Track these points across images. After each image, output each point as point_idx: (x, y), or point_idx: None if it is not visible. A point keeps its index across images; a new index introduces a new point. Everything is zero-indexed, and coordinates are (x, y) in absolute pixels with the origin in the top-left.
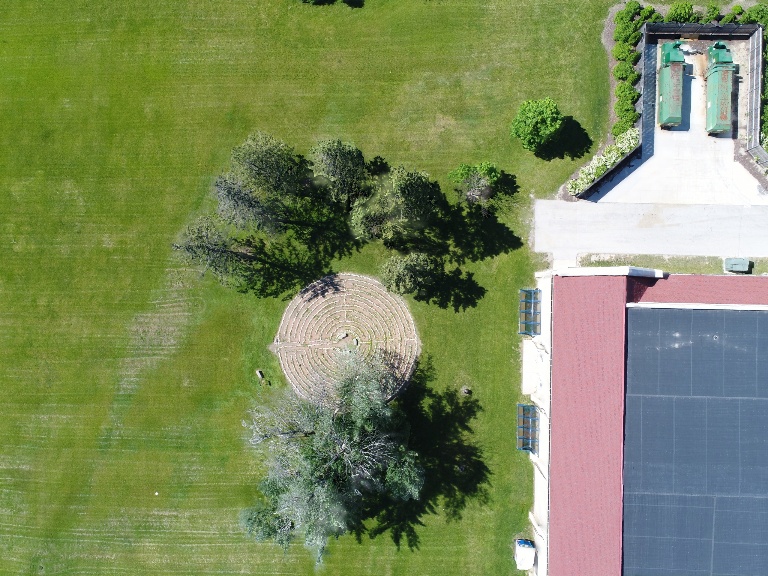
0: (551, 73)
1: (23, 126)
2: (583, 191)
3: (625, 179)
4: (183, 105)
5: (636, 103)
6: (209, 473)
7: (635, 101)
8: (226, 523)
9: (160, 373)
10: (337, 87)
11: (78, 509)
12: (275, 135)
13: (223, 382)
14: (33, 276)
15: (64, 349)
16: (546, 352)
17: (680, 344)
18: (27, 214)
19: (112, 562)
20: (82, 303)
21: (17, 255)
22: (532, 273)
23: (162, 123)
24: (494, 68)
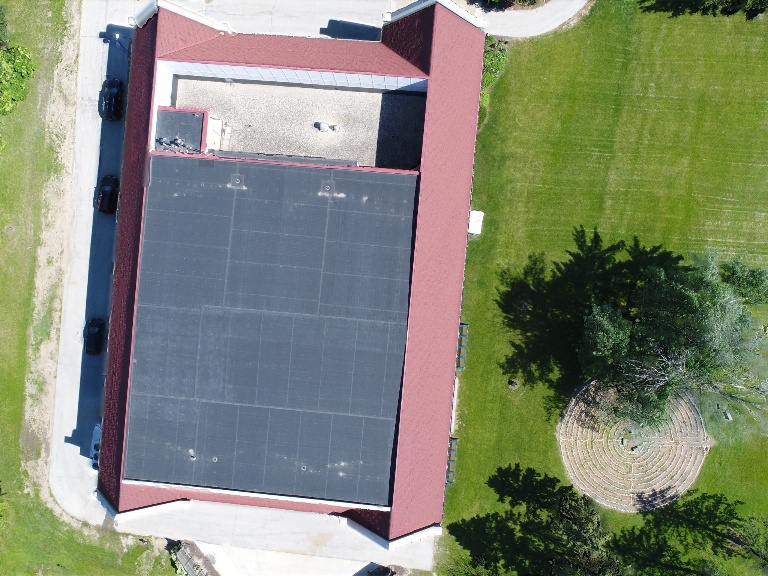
0: None
1: None
2: None
3: None
4: None
5: None
6: None
7: None
8: None
9: None
10: None
11: None
12: None
13: None
14: None
15: None
16: None
17: (339, 465)
18: None
19: None
20: None
21: None
22: None
23: None
24: None
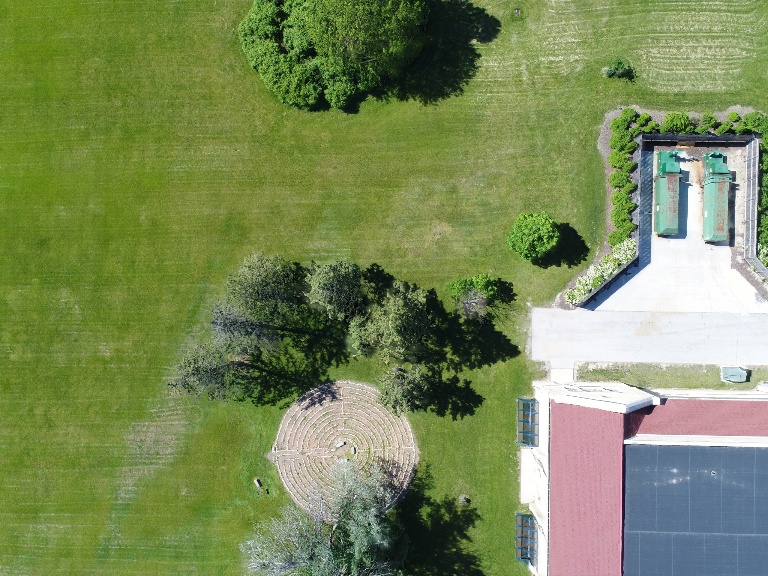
0: (547, 179)
1: (18, 234)
2: (580, 302)
3: (622, 287)
4: (179, 212)
5: (633, 212)
6: None
7: (632, 211)
8: None
9: (158, 482)
10: (333, 194)
11: None
12: (271, 242)
13: (221, 491)
14: (30, 385)
15: (61, 458)
16: (544, 472)
17: (678, 480)
18: (23, 323)
19: None
20: (79, 412)
21: (13, 364)
22: (530, 382)
23: (158, 231)
24: (490, 174)
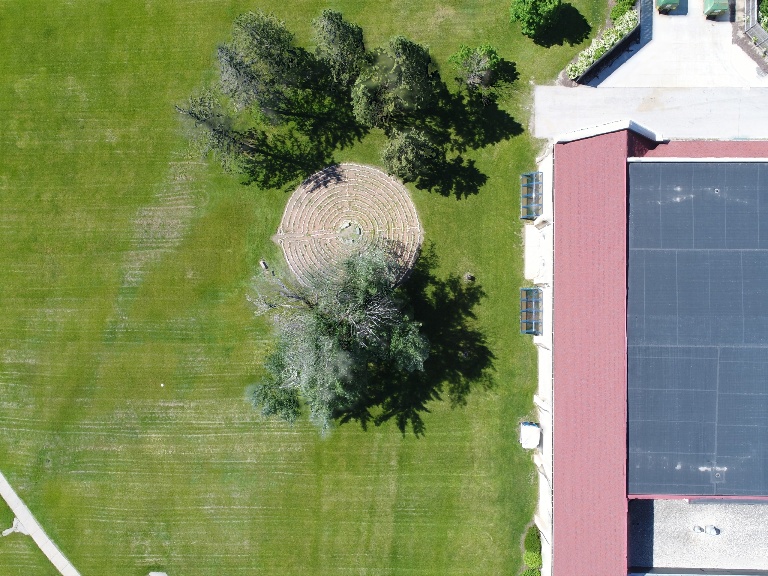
0: None
1: (25, 24)
2: (583, 74)
3: (624, 64)
4: (184, 0)
5: None
6: (214, 364)
7: None
8: (232, 413)
9: (164, 266)
10: None
11: (84, 402)
12: None
13: (227, 273)
14: (37, 172)
15: (68, 243)
16: (548, 225)
17: (681, 198)
18: (30, 111)
19: (119, 454)
20: (86, 197)
21: (21, 151)
22: (533, 159)
23: (163, 18)
24: None
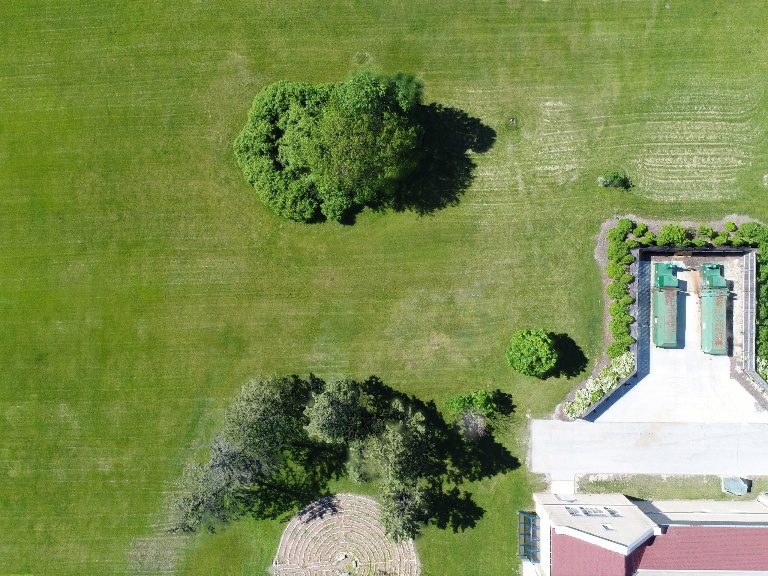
0: (545, 290)
1: (16, 349)
2: None
3: (621, 398)
4: (176, 326)
5: (631, 324)
6: None
7: (630, 323)
8: None
9: None
10: (330, 305)
11: None
12: (269, 355)
13: None
14: (29, 502)
15: (62, 575)
16: None
17: None
18: (22, 439)
19: None
20: (79, 528)
21: (13, 480)
22: (530, 494)
23: (155, 345)
24: (488, 285)
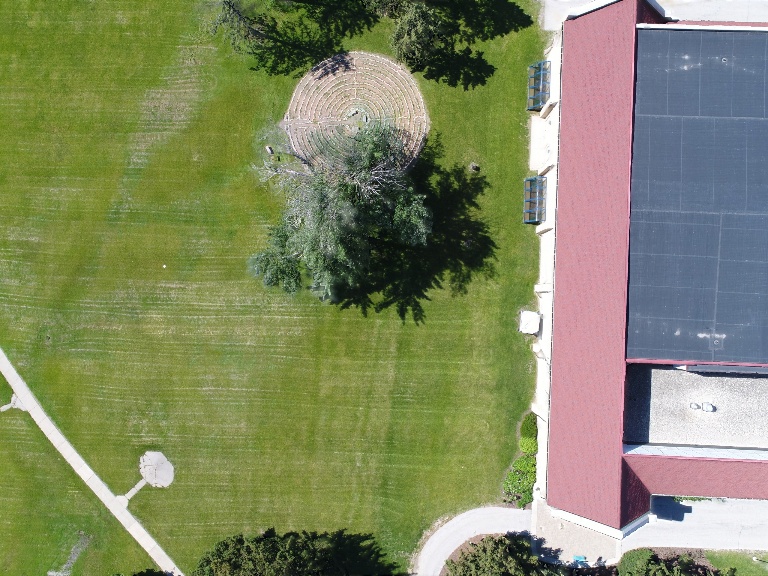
0: None
1: None
2: None
3: None
4: None
5: None
6: (217, 247)
7: None
8: (233, 295)
9: (170, 148)
10: None
11: (86, 281)
12: None
13: (233, 157)
14: (46, 51)
15: (76, 123)
16: (555, 105)
17: (689, 66)
18: None
19: (119, 333)
20: (94, 78)
21: (31, 30)
22: (541, 51)
23: None
24: None
